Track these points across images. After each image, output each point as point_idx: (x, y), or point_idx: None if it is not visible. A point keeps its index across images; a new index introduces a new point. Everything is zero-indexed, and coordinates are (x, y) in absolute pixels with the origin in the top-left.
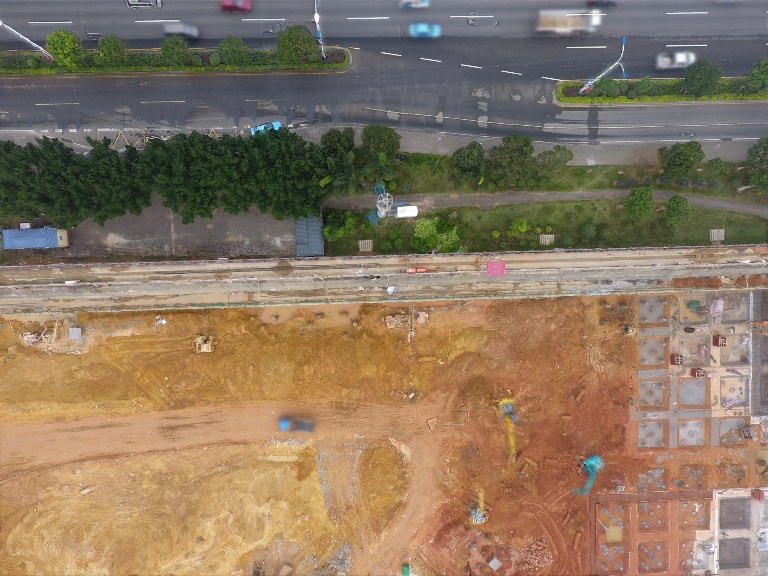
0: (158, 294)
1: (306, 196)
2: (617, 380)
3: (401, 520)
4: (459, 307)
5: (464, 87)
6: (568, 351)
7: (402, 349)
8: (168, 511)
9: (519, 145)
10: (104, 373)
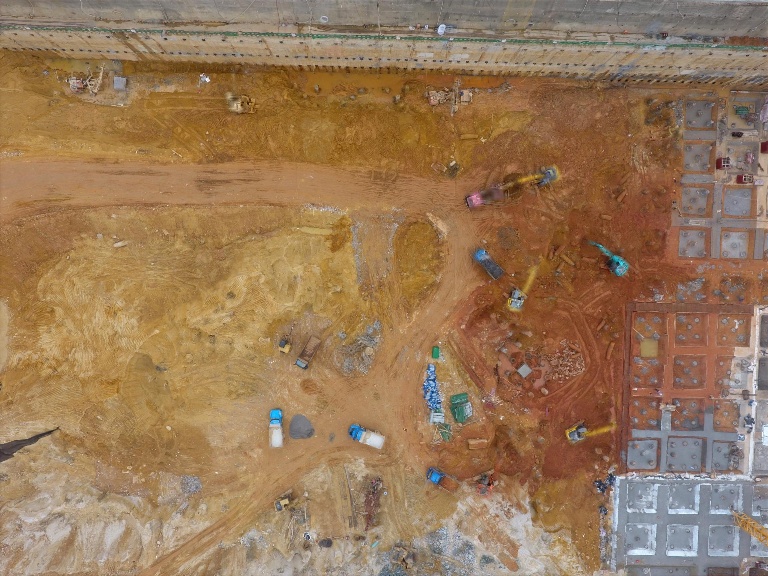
0: (209, 20)
1: None
2: (660, 183)
3: (433, 301)
4: (504, 90)
5: None
6: (613, 138)
7: (444, 125)
8: (199, 276)
9: None
10: (145, 126)
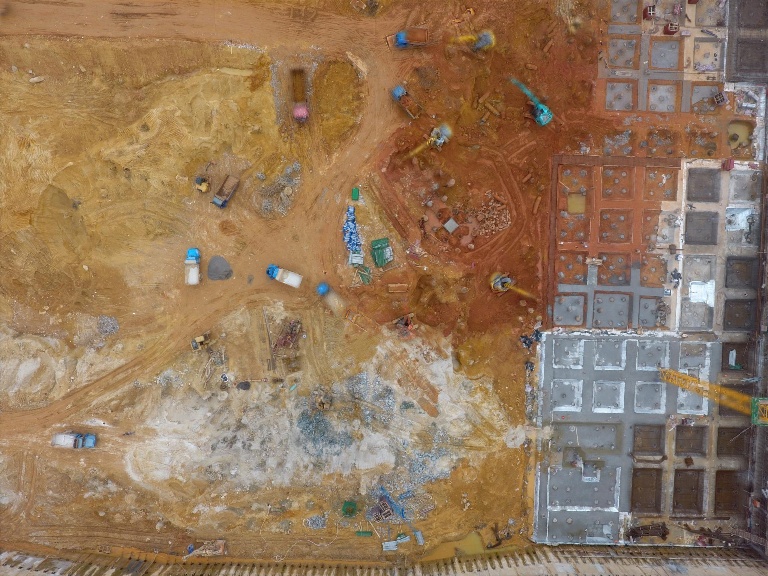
0: None
1: None
2: (587, 33)
3: (354, 143)
4: None
5: None
6: None
7: None
8: (117, 115)
9: None
10: None
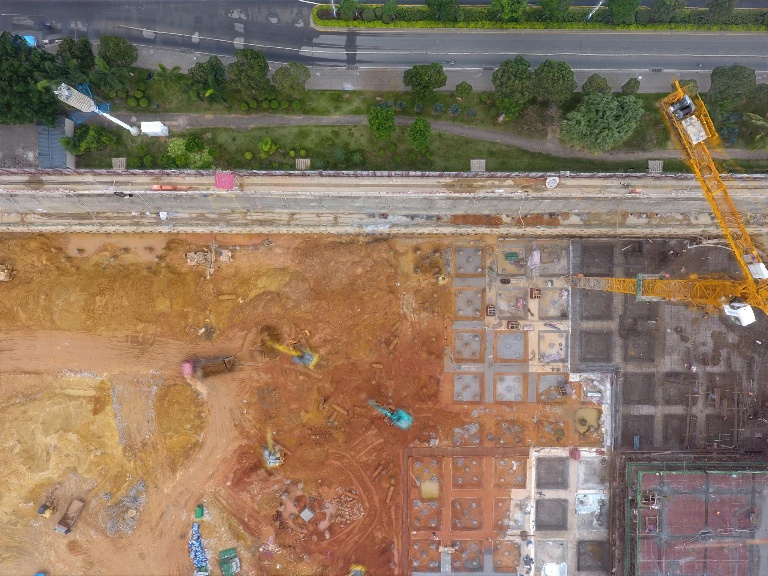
0: None
1: (30, 101)
2: (431, 330)
3: (197, 460)
4: (265, 247)
5: (221, 8)
6: (371, 295)
7: (202, 286)
8: None
9: (248, 58)
10: None
